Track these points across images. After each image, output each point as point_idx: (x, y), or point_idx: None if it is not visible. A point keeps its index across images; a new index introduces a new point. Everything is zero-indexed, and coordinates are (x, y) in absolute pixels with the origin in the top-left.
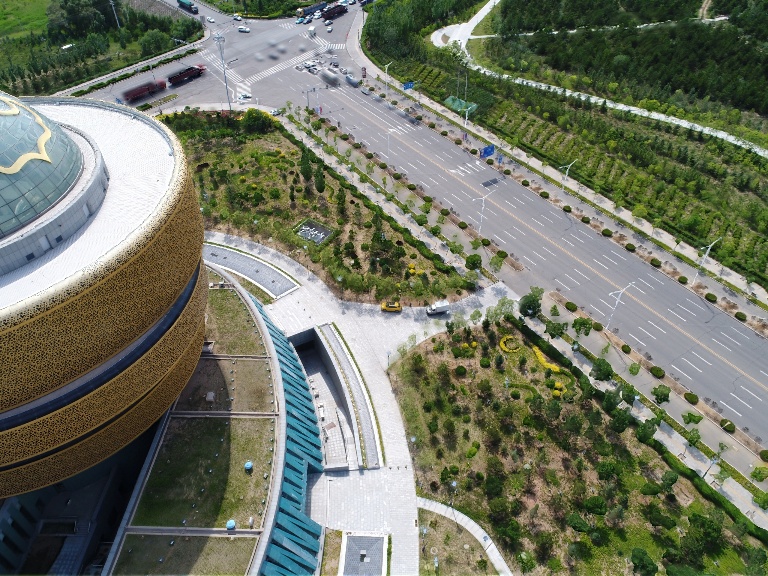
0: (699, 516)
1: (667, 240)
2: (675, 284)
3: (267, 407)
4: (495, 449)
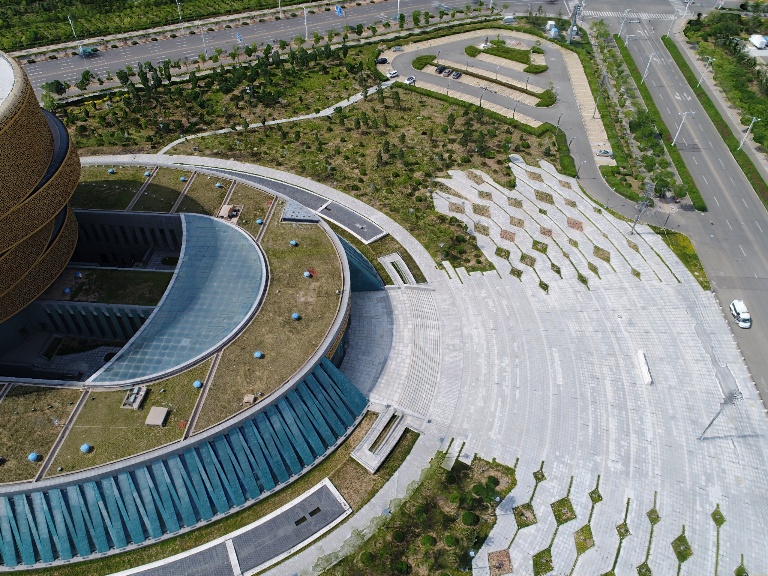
0: (213, 75)
1: (37, 51)
2: (75, 57)
3: None
4: None
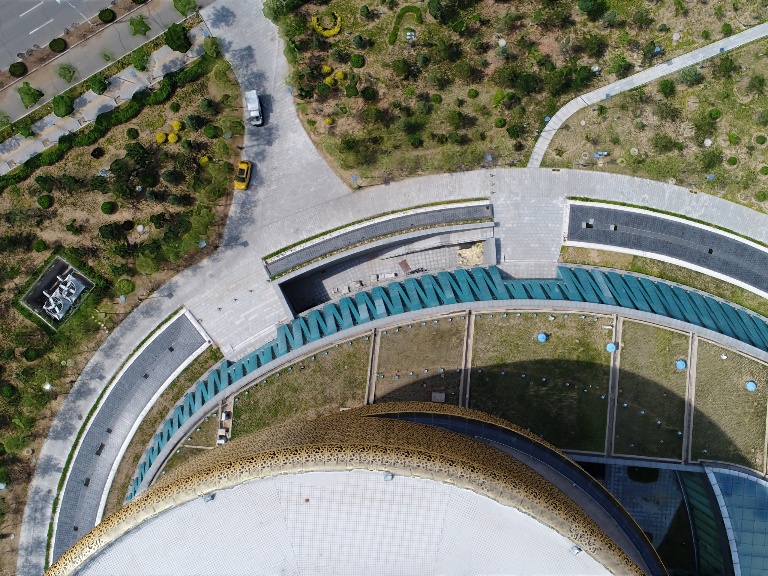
0: None
1: None
2: None
3: (457, 326)
4: (478, 74)
